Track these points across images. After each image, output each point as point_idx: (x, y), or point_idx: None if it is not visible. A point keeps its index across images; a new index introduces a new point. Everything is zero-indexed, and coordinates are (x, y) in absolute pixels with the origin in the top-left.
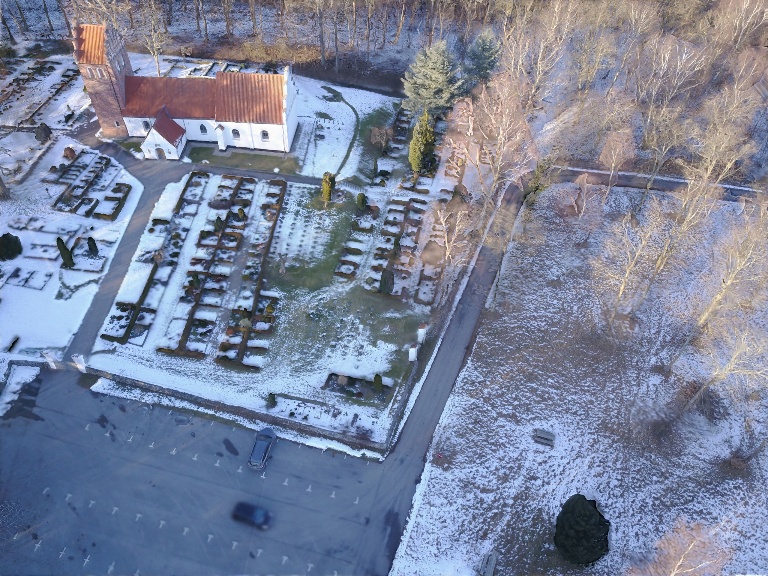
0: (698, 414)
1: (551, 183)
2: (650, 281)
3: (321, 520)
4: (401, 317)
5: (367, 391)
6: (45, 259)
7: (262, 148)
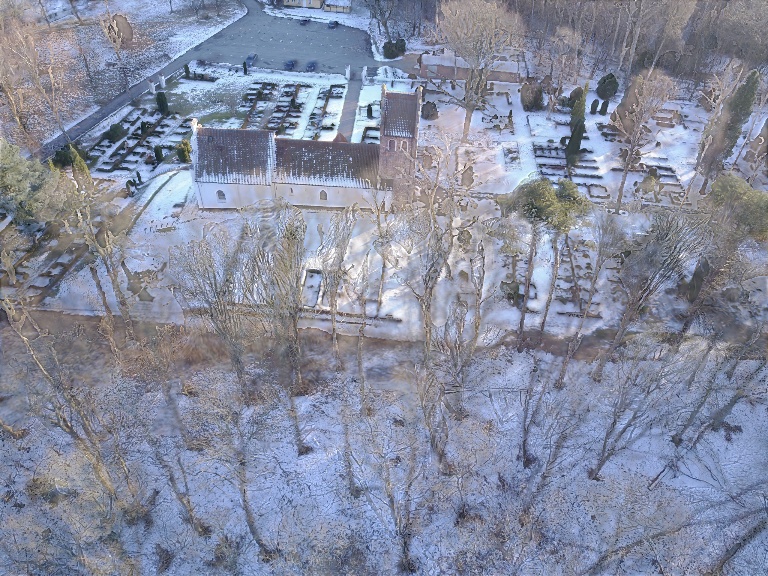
0: None
1: None
2: None
3: (227, 50)
4: None
5: None
6: None
7: None
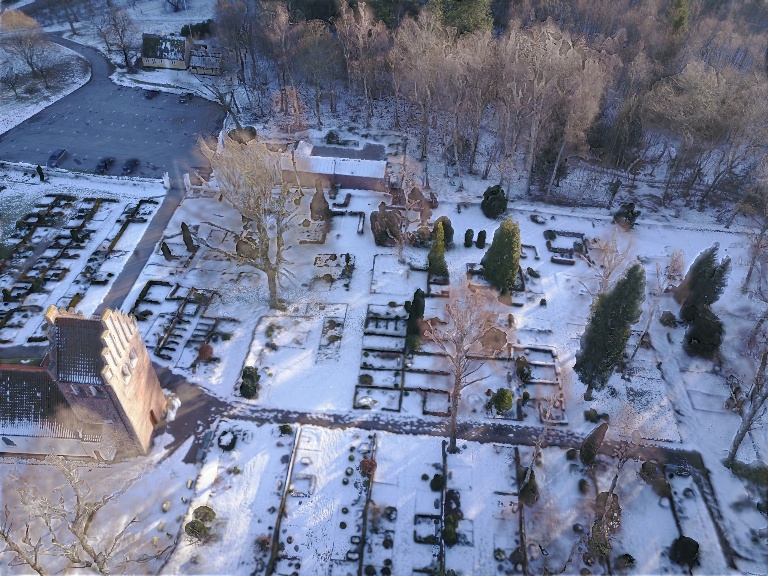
0: None
1: None
2: None
3: (37, 141)
4: None
5: None
6: None
7: None
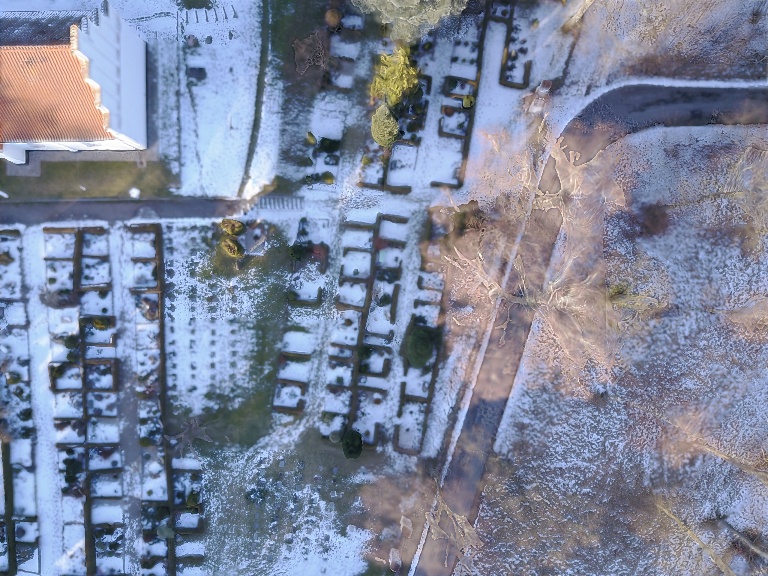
0: (741, 559)
1: (627, 133)
2: (741, 369)
3: None
4: (376, 480)
5: None
6: None
7: (93, 149)
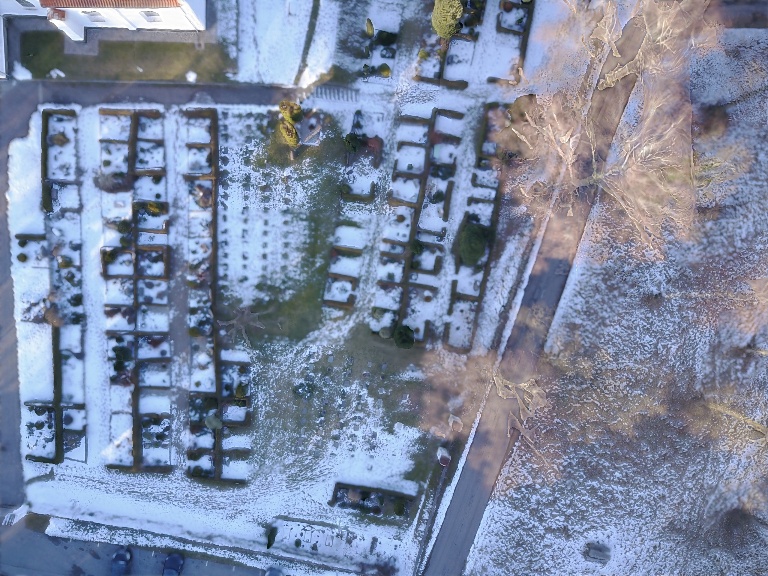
0: None
1: None
2: None
3: None
4: (425, 378)
5: (386, 503)
6: None
7: (152, 27)
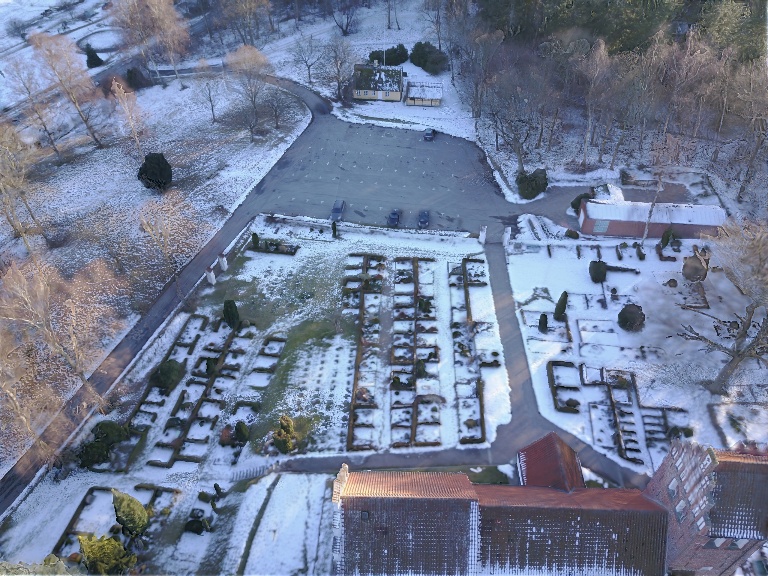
0: None
1: None
2: None
3: (300, 190)
4: None
5: None
6: (588, 320)
7: None
